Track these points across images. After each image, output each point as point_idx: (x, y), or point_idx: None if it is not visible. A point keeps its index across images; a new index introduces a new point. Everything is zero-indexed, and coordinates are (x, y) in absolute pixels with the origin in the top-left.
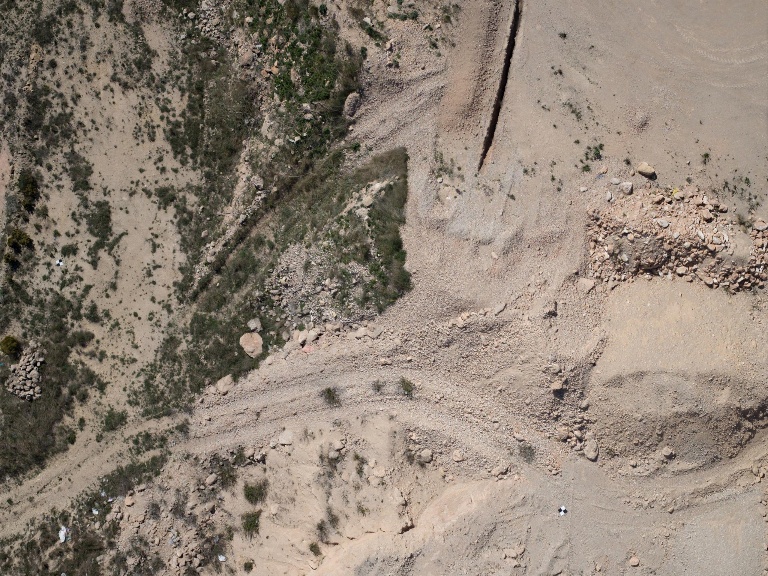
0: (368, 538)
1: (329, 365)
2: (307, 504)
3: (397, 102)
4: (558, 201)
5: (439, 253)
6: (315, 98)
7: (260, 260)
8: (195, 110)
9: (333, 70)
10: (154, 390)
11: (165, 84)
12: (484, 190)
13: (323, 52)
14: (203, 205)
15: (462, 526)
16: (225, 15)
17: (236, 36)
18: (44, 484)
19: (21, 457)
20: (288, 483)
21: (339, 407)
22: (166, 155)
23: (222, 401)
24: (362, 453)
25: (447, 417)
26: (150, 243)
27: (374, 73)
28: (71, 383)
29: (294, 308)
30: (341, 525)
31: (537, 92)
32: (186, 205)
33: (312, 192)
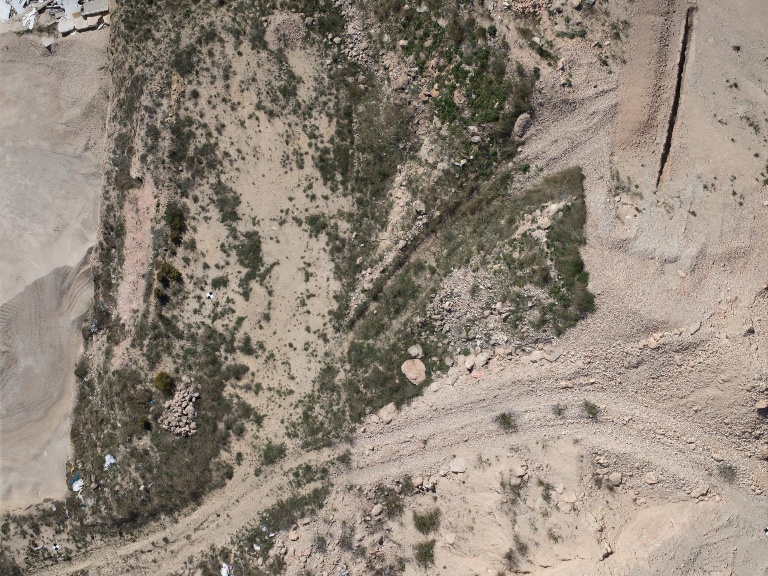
0: (568, 566)
1: (503, 390)
2: (488, 532)
3: (570, 121)
4: (741, 216)
5: (624, 273)
6: (483, 120)
7: (420, 285)
8: (344, 136)
9: (503, 91)
10: (313, 421)
11: (312, 110)
12: (664, 207)
13: (491, 73)
14: (356, 231)
15: (667, 550)
16: (374, 39)
17: (387, 60)
18: (201, 521)
19: (178, 495)
20: (464, 511)
21: (515, 432)
22: (315, 182)
23: (385, 430)
24: (547, 479)
25: (637, 439)
26: (303, 272)
27: (547, 93)
28: (227, 417)
29: (458, 333)
30: (531, 553)
31: (713, 106)
32: (338, 232)
33: (477, 215)
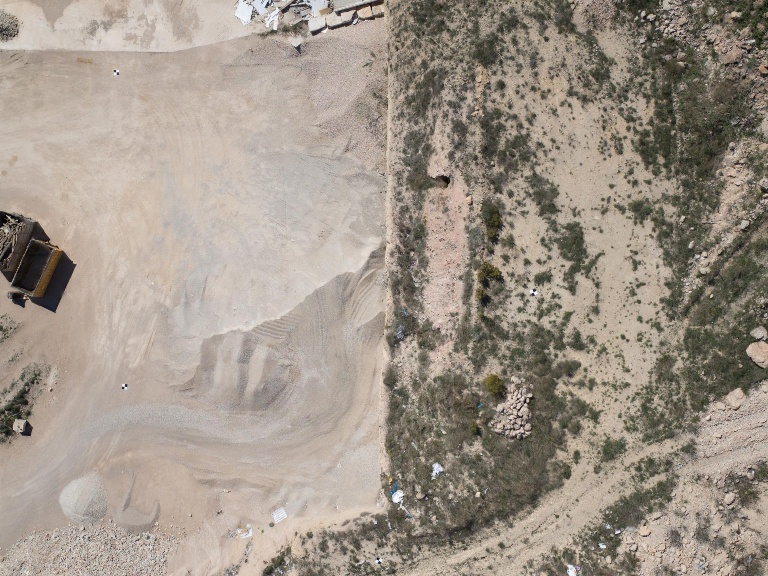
0: None
1: None
2: None
3: None
4: None
5: None
6: None
7: (763, 266)
8: (664, 116)
9: None
10: (652, 413)
11: (627, 93)
12: None
13: None
14: (683, 215)
15: None
16: (697, 13)
17: (712, 34)
18: (539, 523)
19: (515, 499)
20: None
21: None
22: (636, 167)
23: (734, 416)
24: None
25: None
26: (630, 261)
27: None
28: (561, 416)
29: None
30: None
31: None
32: (664, 217)
33: None
